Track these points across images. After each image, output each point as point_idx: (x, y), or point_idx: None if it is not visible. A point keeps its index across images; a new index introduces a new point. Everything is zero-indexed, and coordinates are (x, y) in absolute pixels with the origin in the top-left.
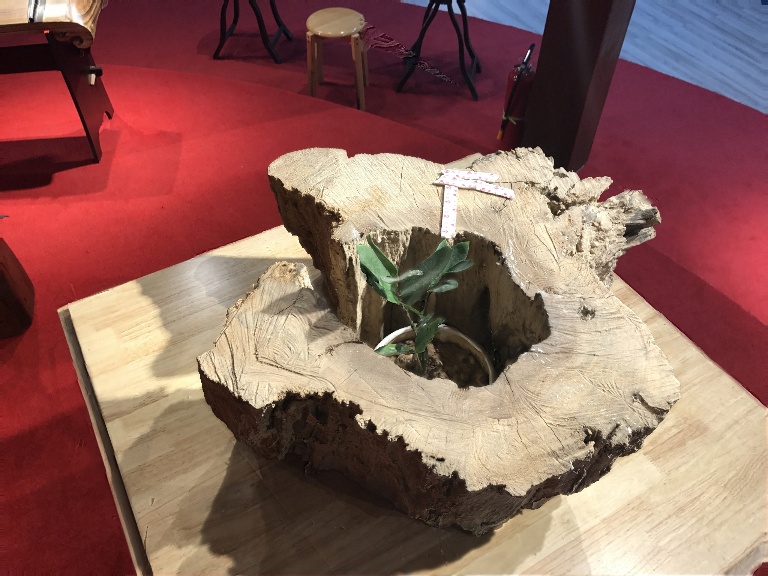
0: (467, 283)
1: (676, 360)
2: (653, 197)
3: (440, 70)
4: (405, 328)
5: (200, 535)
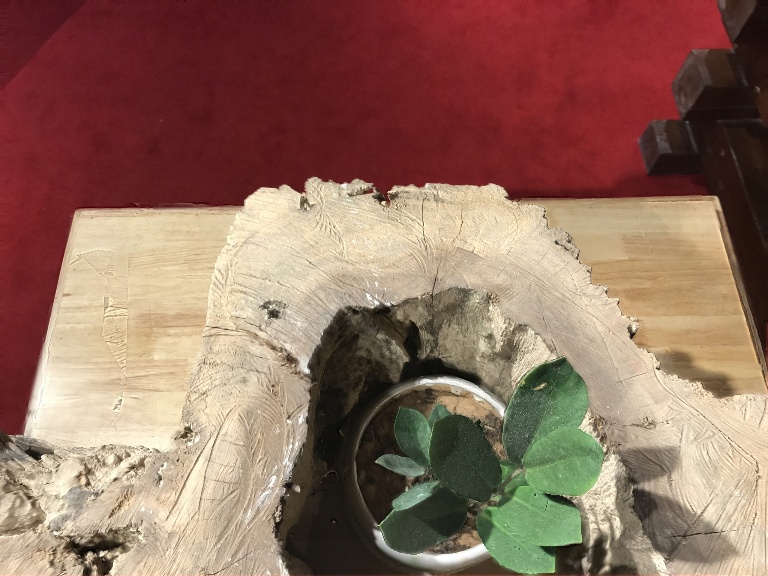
0: (305, 575)
1: (79, 402)
2: (109, 274)
3: None
4: (435, 559)
5: None
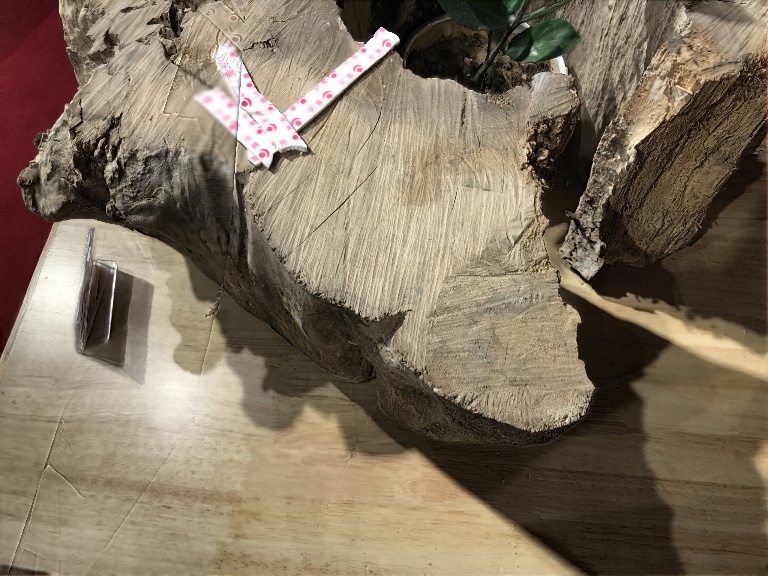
0: None
1: None
2: None
3: (208, 4)
4: None
5: (764, 171)
